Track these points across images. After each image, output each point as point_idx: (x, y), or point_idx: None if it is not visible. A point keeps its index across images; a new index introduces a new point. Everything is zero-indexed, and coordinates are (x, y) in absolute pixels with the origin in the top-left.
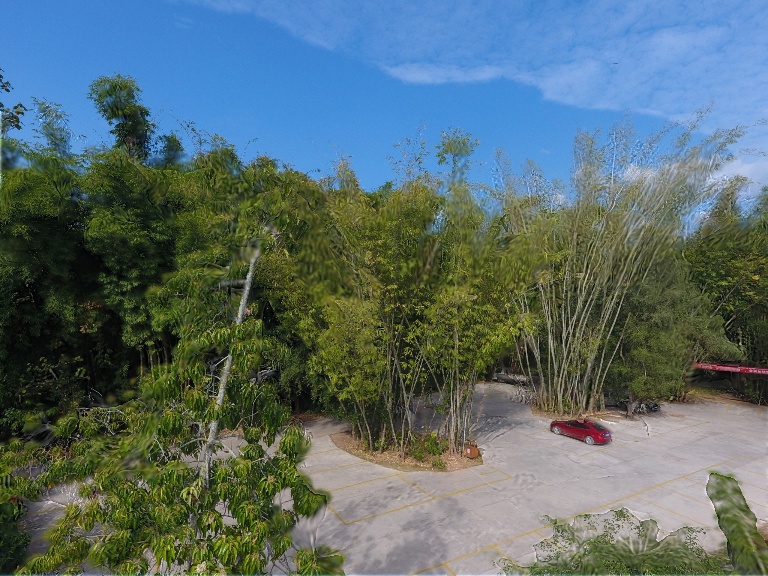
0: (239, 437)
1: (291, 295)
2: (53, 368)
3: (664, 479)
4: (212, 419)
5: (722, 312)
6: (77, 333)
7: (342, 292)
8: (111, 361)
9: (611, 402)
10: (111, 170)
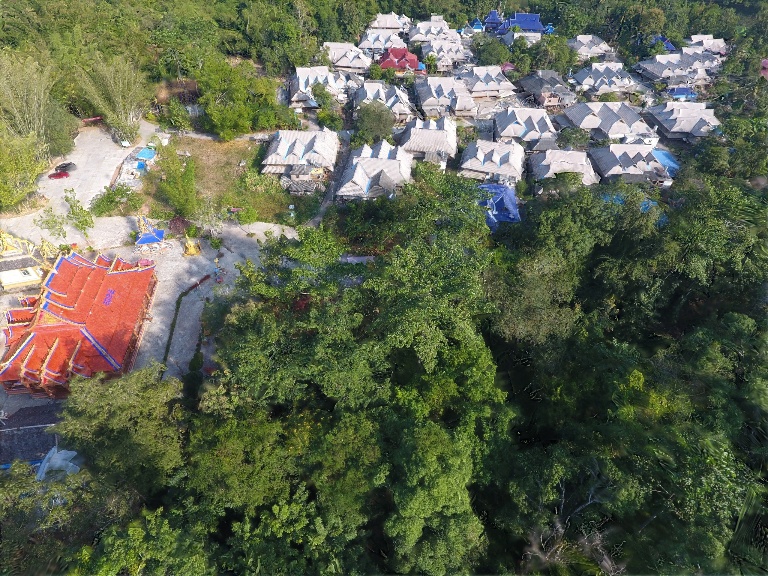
0: None
1: None
2: None
3: (90, 179)
4: None
5: (68, 104)
6: None
7: None
8: None
9: (52, 155)
10: None
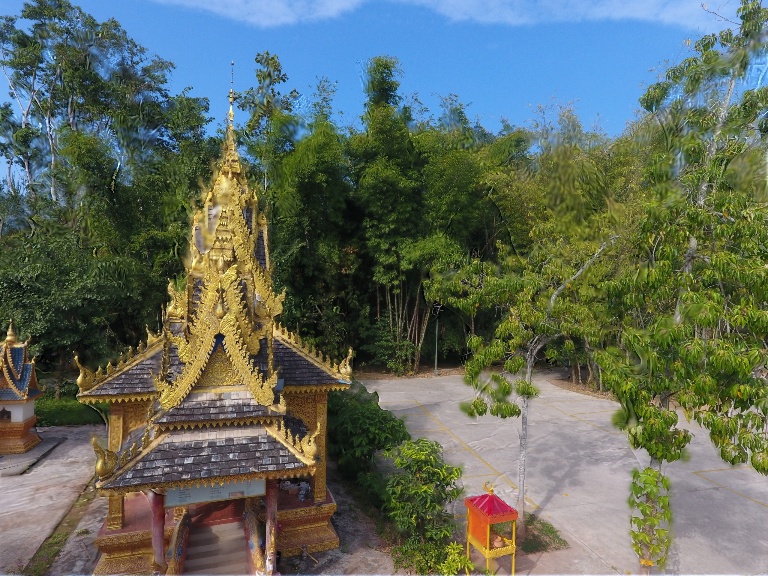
0: None
1: (543, 224)
2: (318, 305)
3: None
4: None
5: None
6: (337, 275)
7: (586, 224)
8: (358, 302)
9: None
10: (390, 121)
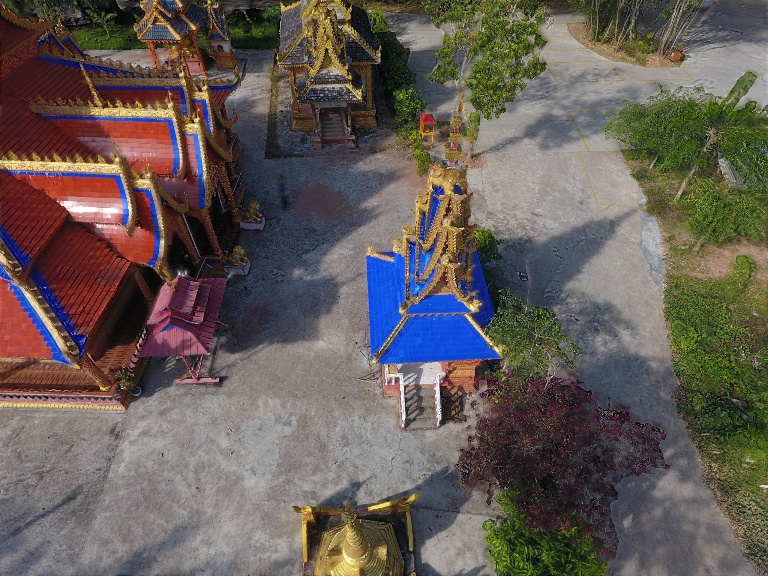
0: (522, 12)
1: None
2: None
3: None
4: (515, 4)
5: None
6: None
7: None
8: None
9: None
10: None
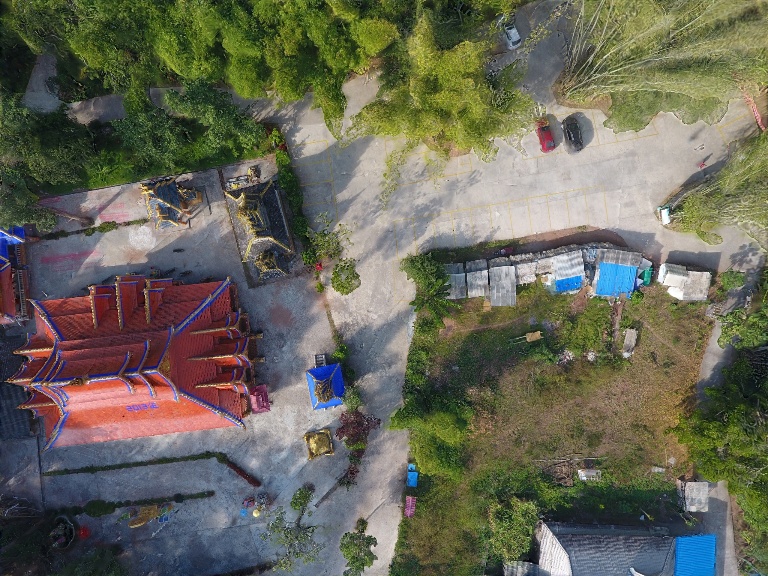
0: None
1: None
2: None
3: (535, 195)
4: None
5: None
6: None
7: None
8: None
9: None
10: None
